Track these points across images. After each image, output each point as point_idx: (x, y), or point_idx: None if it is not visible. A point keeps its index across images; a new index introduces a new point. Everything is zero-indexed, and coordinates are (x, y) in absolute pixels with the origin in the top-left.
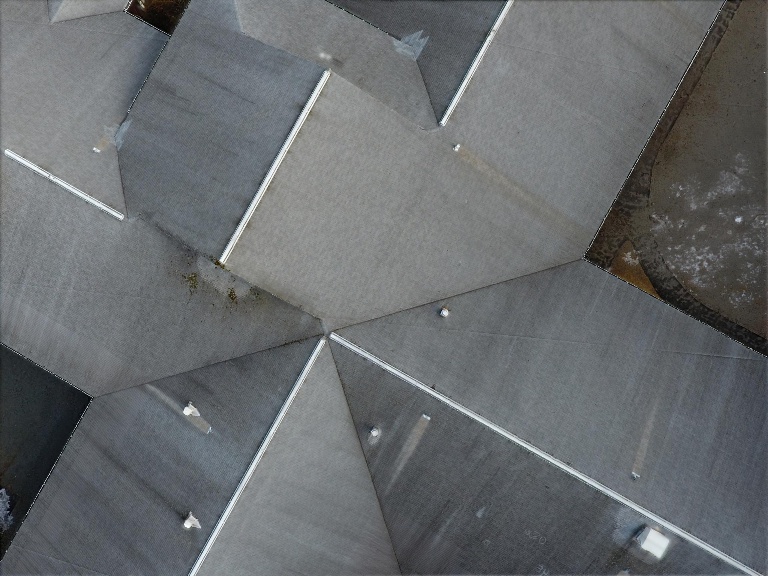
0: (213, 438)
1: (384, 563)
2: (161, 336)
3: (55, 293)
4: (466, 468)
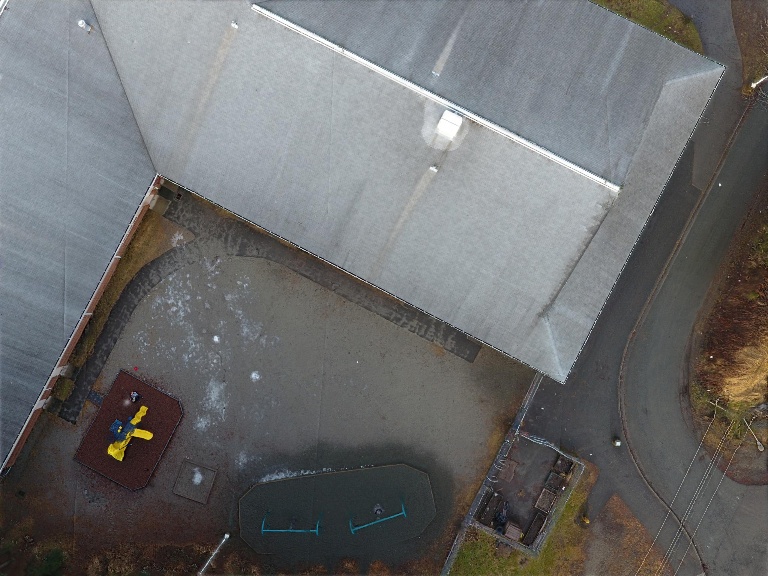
0: None
1: None
2: None
3: None
4: None
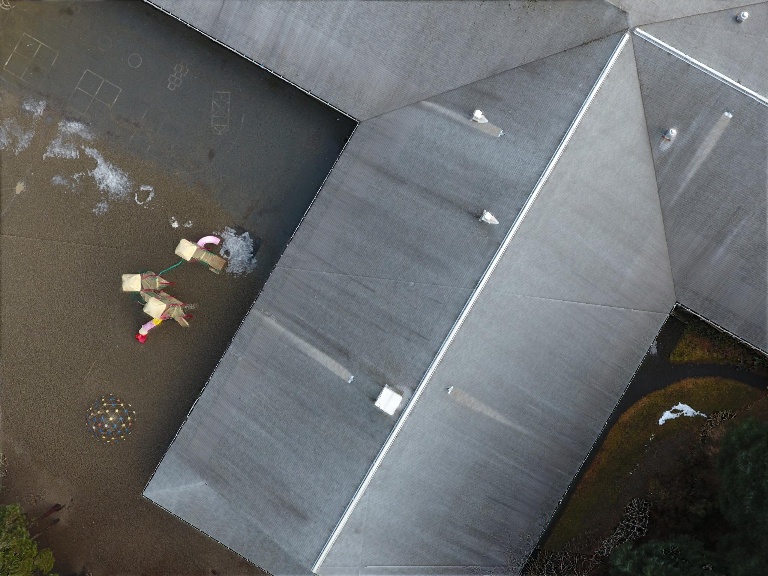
0: (506, 140)
1: (661, 280)
2: (446, 45)
3: (334, 5)
4: (764, 169)
